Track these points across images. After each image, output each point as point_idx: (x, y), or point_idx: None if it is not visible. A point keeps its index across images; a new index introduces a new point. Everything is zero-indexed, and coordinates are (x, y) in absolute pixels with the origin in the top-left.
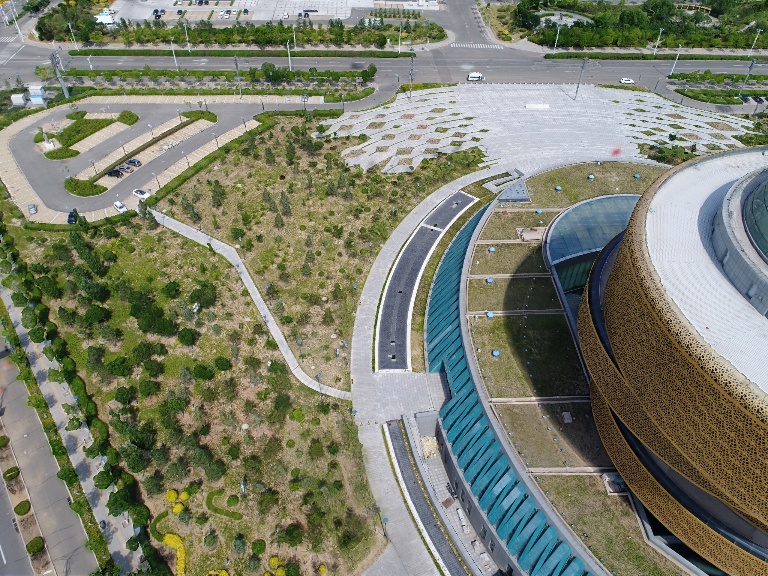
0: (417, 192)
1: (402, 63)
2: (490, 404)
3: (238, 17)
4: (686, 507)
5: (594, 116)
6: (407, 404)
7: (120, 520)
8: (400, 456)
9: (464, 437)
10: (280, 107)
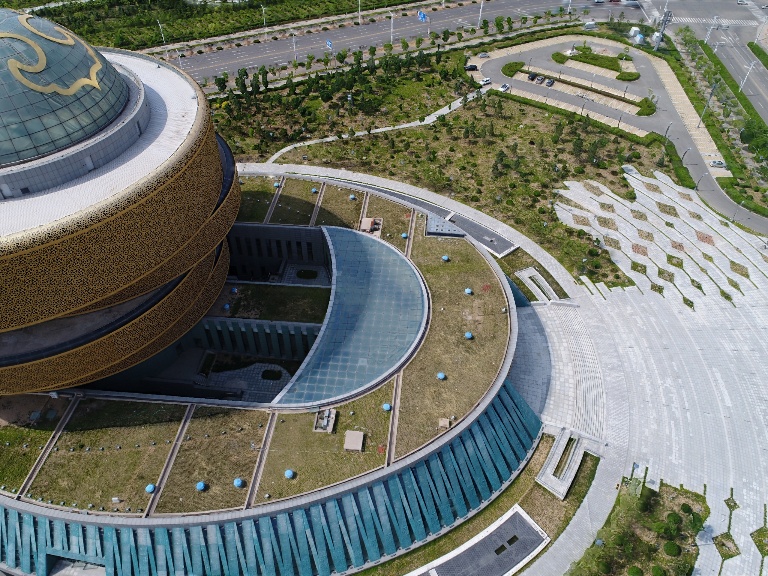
0: None
1: None
2: None
3: None
4: None
5: None
6: None
7: None
8: None
9: None
10: None
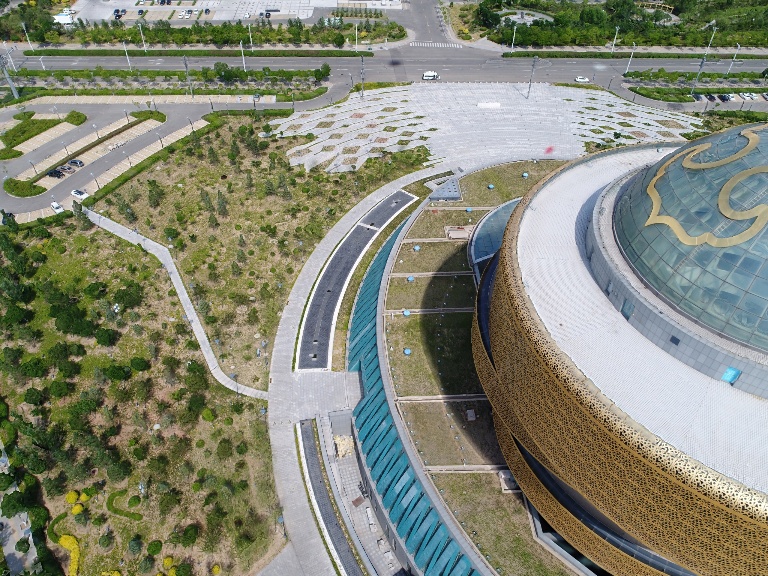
0: (358, 191)
1: (359, 62)
2: (396, 402)
3: (199, 17)
4: (563, 504)
5: (545, 114)
6: (323, 403)
7: (18, 522)
8: (309, 455)
9: (372, 436)
10: (231, 107)
